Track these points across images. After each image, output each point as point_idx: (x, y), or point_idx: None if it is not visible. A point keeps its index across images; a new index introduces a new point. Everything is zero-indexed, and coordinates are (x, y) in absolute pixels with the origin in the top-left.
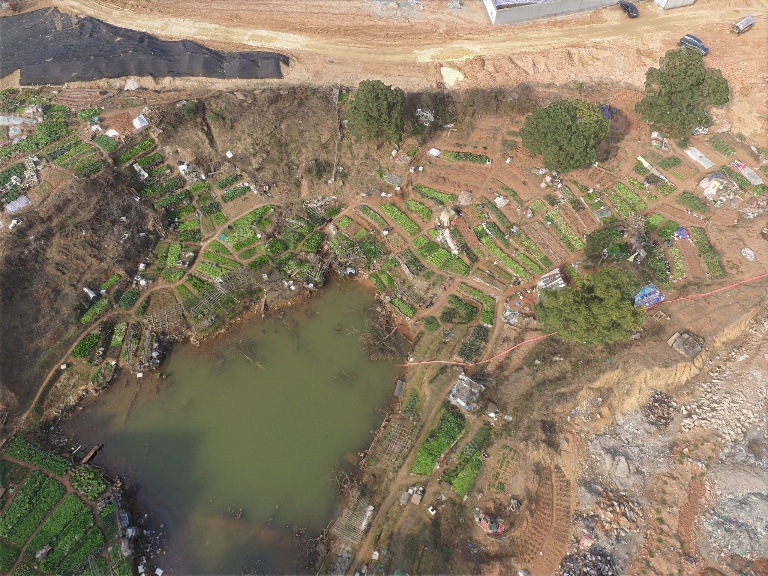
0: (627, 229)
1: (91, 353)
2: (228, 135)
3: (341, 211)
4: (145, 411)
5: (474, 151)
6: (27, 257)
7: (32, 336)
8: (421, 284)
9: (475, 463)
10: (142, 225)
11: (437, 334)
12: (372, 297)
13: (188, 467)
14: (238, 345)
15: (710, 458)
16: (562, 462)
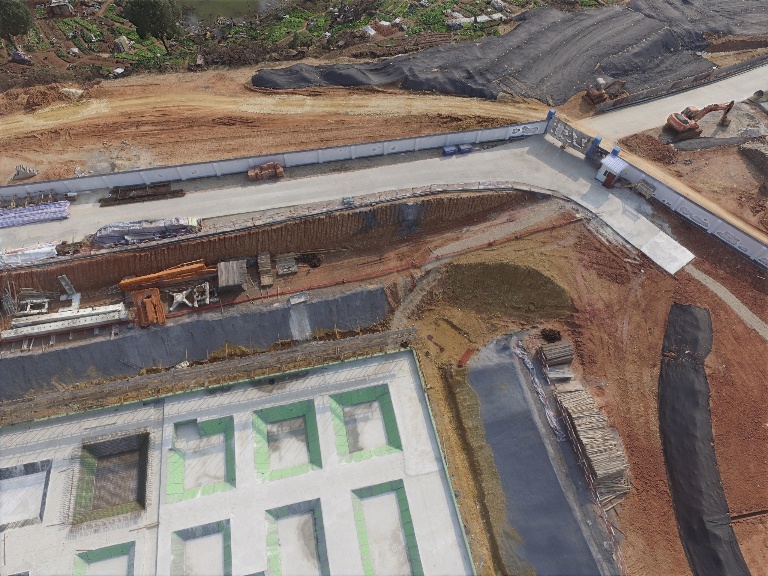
0: None
1: None
2: None
3: None
4: None
5: None
6: None
7: None
8: None
9: None
10: None
11: None
12: (189, 29)
13: None
14: None
15: None
16: None
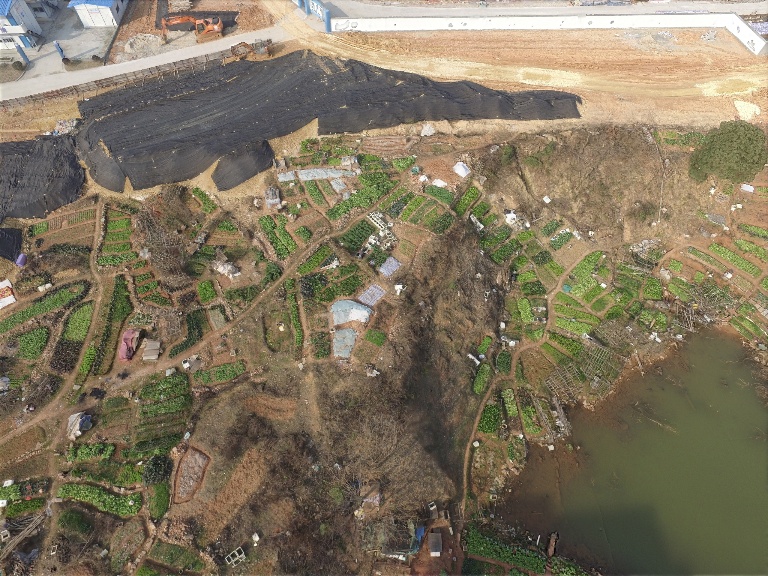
0: None
1: (497, 427)
2: (544, 179)
3: (664, 254)
4: (575, 489)
5: None
6: (424, 325)
7: (443, 413)
8: None
9: None
10: (491, 280)
11: None
12: (739, 345)
13: (657, 551)
14: (634, 407)
15: None
16: None
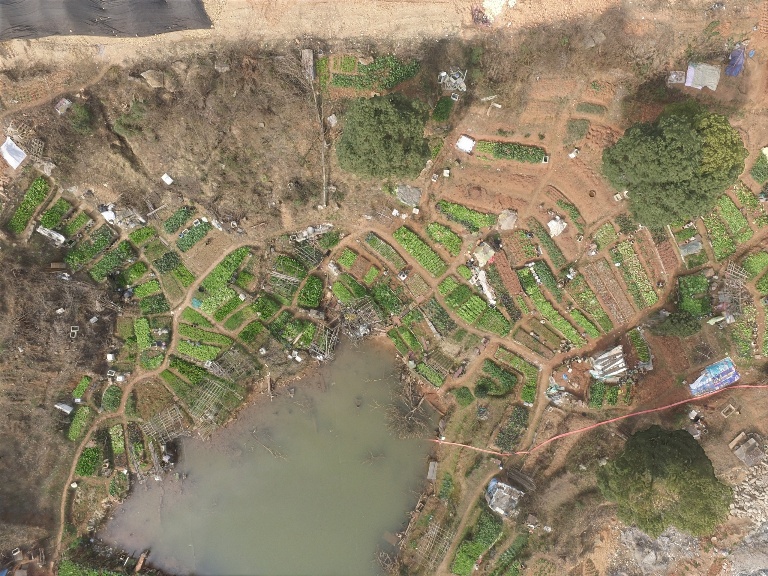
0: (718, 277)
1: (97, 467)
2: (155, 151)
3: (340, 239)
4: (177, 511)
5: (525, 140)
6: None
7: (24, 470)
8: (451, 348)
9: (513, 572)
10: (87, 307)
11: (471, 409)
12: (393, 358)
13: (237, 559)
14: (252, 434)
15: (735, 545)
16: (594, 557)
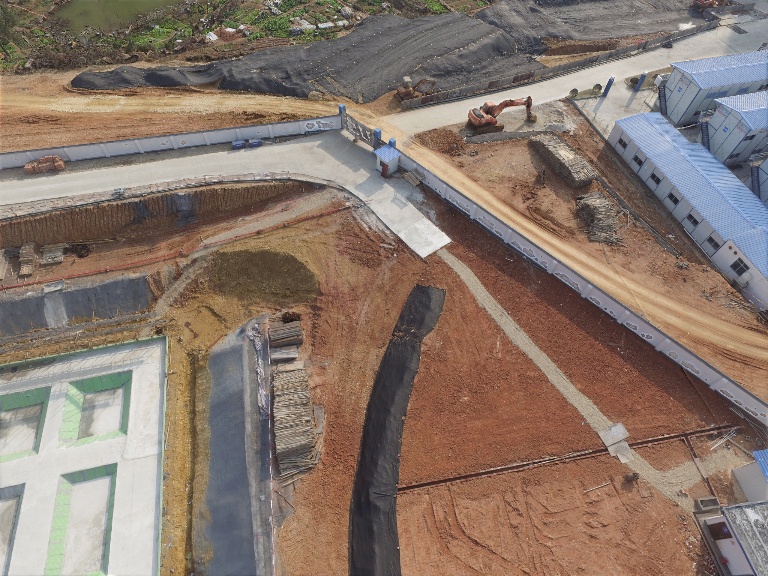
0: None
1: None
2: None
3: None
4: None
5: None
6: None
7: None
8: None
9: None
10: None
11: None
12: None
13: None
14: None
15: None
16: None
